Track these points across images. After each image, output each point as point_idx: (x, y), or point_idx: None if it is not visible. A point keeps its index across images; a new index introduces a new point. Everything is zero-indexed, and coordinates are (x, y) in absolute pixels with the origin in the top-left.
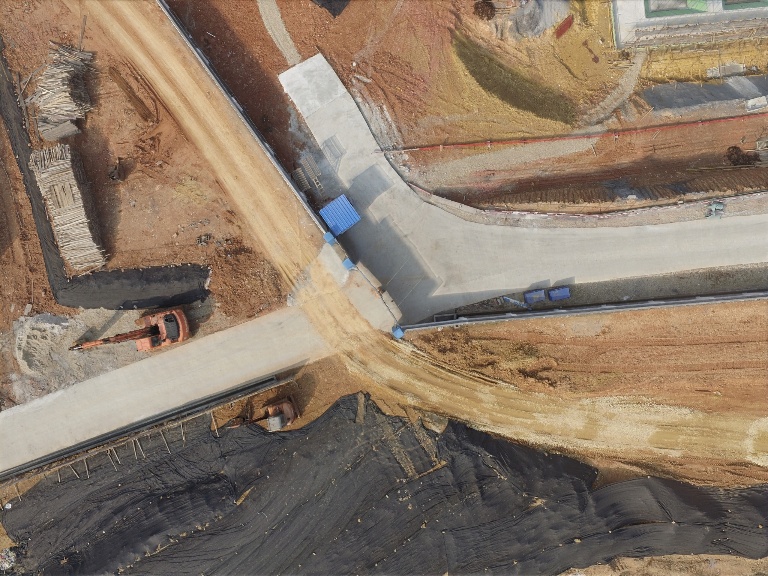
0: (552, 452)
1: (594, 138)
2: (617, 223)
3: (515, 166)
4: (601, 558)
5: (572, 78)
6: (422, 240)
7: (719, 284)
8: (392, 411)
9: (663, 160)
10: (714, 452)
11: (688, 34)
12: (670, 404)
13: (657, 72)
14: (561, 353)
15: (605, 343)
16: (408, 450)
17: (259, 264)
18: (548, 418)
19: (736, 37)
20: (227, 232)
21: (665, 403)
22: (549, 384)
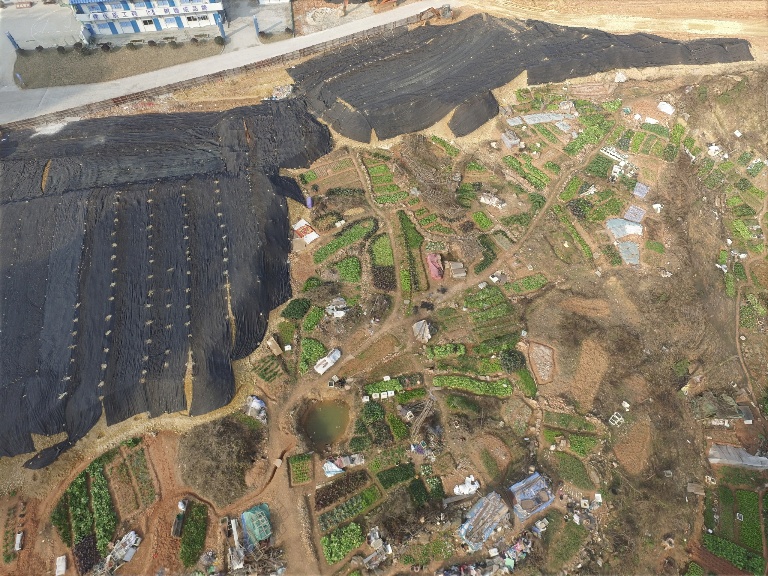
0: None
1: None
2: None
3: None
4: (630, 64)
5: None
6: None
7: None
8: None
9: None
10: (669, 29)
11: None
12: None
13: None
14: (576, 2)
15: None
16: None
17: None
18: (579, 20)
19: None
20: None
21: (635, 16)
22: None
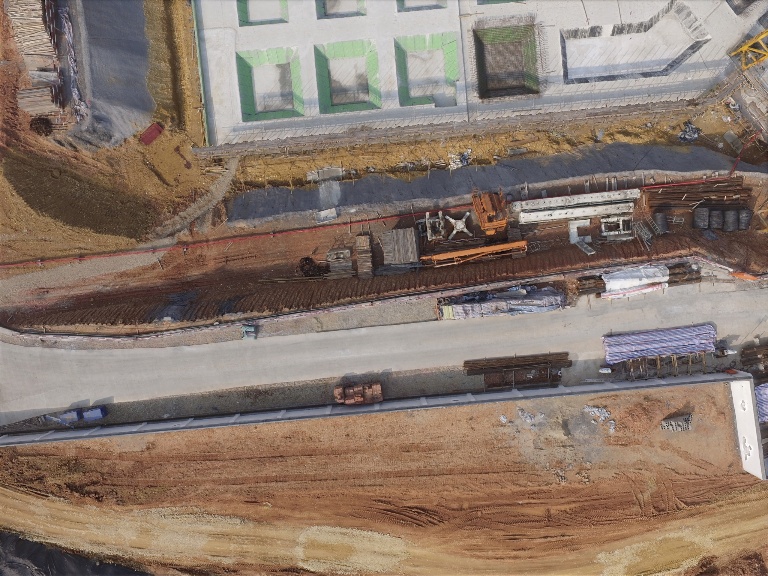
0: (106, 561)
1: (160, 252)
2: (155, 344)
3: (72, 282)
4: None
5: (161, 185)
6: None
7: (258, 402)
8: None
9: (236, 271)
10: (266, 559)
11: (245, 150)
12: (221, 514)
13: (257, 176)
14: (108, 468)
15: (150, 458)
16: None
17: None
18: (101, 529)
19: (310, 148)
20: None
21: (216, 513)
22: (96, 498)
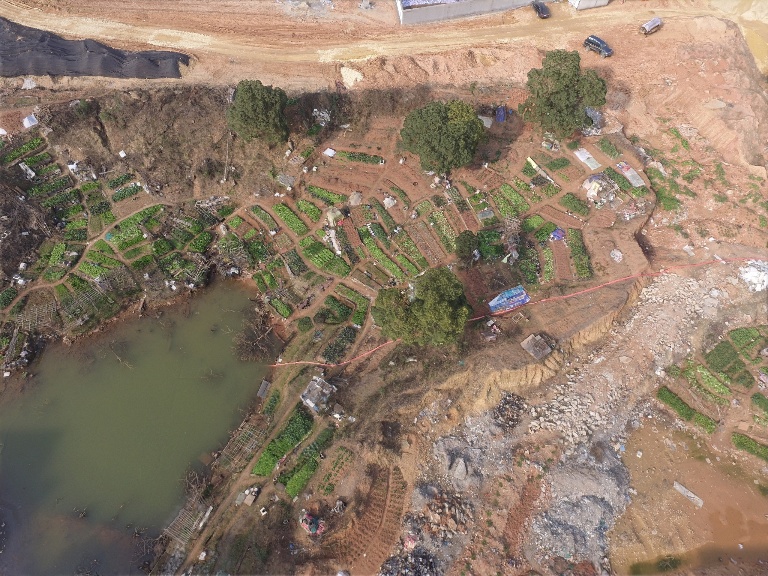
0: None
1: None
2: None
3: None
4: (46, 72)
5: None
6: None
7: None
8: None
9: None
10: (131, 38)
11: None
12: (118, 22)
13: None
14: None
15: (95, 0)
16: None
17: None
18: (51, 21)
19: None
20: None
21: None
22: (58, 8)
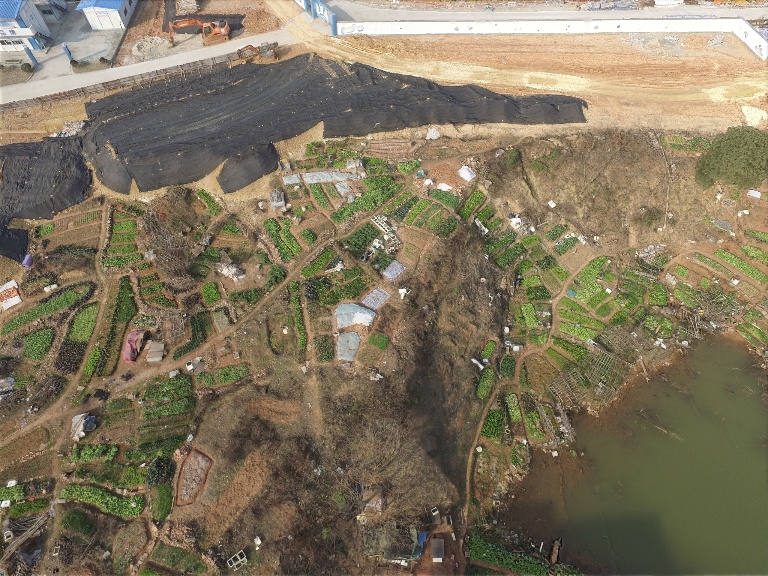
0: None
1: None
2: (443, 11)
3: None
4: (447, 120)
5: None
6: (350, 11)
7: None
8: (328, 58)
9: None
10: (507, 82)
11: None
12: None
13: None
14: (418, 45)
15: (441, 43)
16: (334, 69)
17: (270, 17)
18: (413, 66)
19: None
20: (258, 7)
21: (476, 65)
22: None
